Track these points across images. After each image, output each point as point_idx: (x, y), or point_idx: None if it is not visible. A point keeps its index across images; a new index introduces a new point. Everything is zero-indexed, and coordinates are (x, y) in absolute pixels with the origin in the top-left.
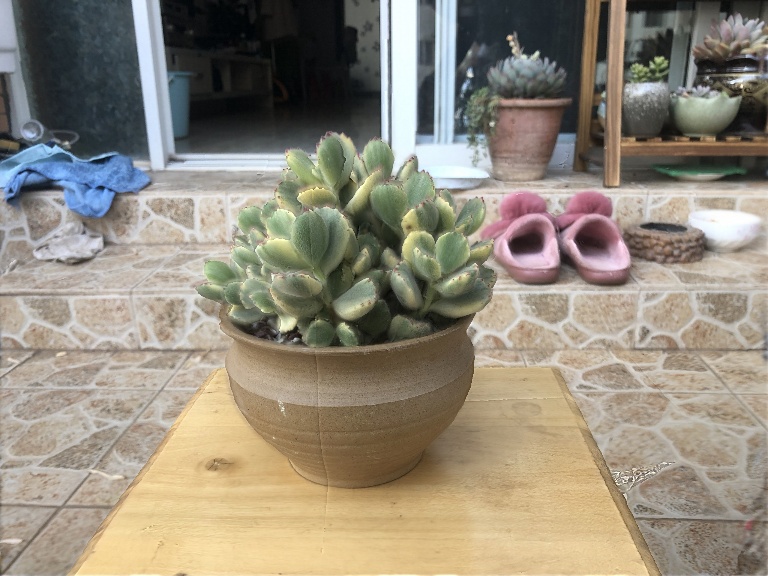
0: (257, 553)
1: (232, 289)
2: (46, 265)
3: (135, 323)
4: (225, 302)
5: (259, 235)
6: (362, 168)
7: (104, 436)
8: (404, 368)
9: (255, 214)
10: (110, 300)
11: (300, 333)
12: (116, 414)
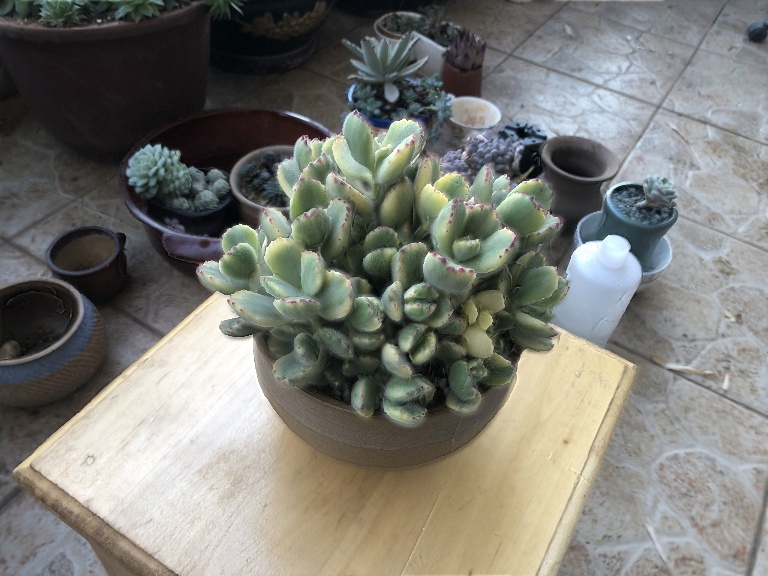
0: None
1: None
2: None
3: None
4: None
5: None
6: None
7: None
8: None
9: (494, 185)
10: None
11: None
12: None
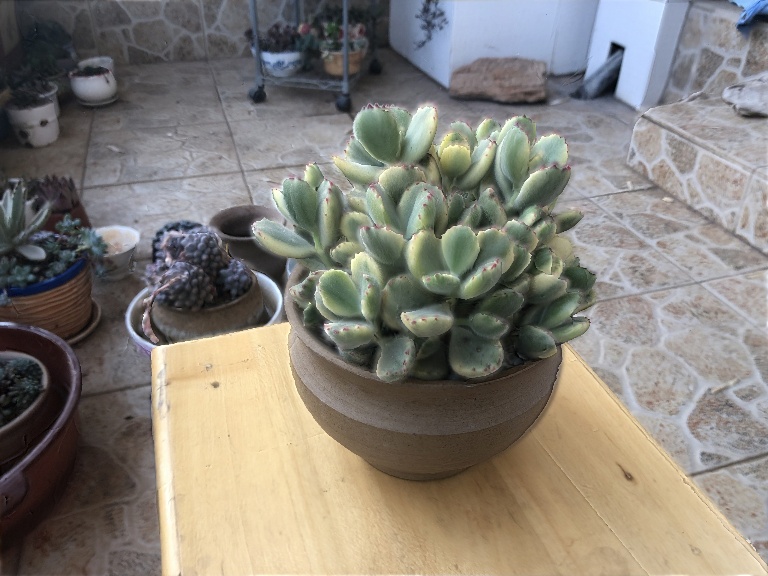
0: (249, 414)
1: None
2: (721, 107)
3: (742, 204)
4: None
5: None
6: (499, 153)
7: (605, 289)
8: (334, 375)
9: None
10: (732, 169)
11: None
12: (637, 278)
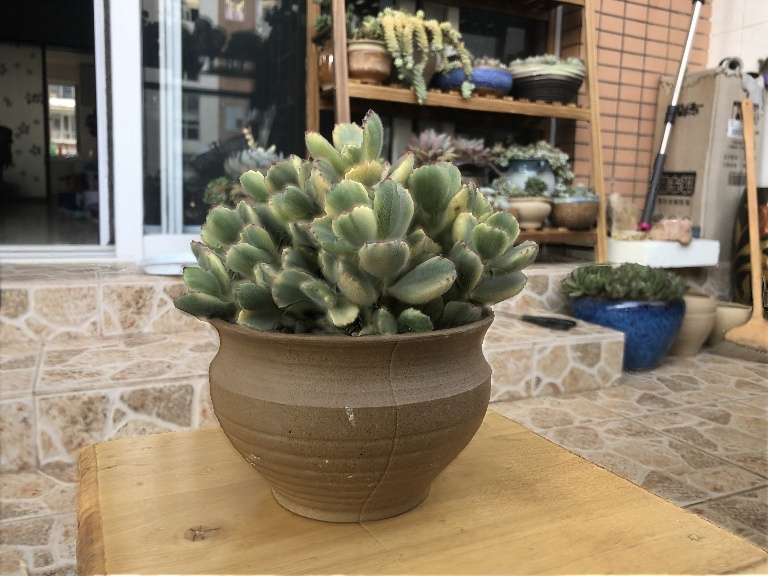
0: None
1: (247, 290)
2: None
3: None
4: (214, 315)
5: (263, 230)
6: None
7: None
8: (465, 356)
9: (231, 215)
10: None
11: (360, 326)
12: None
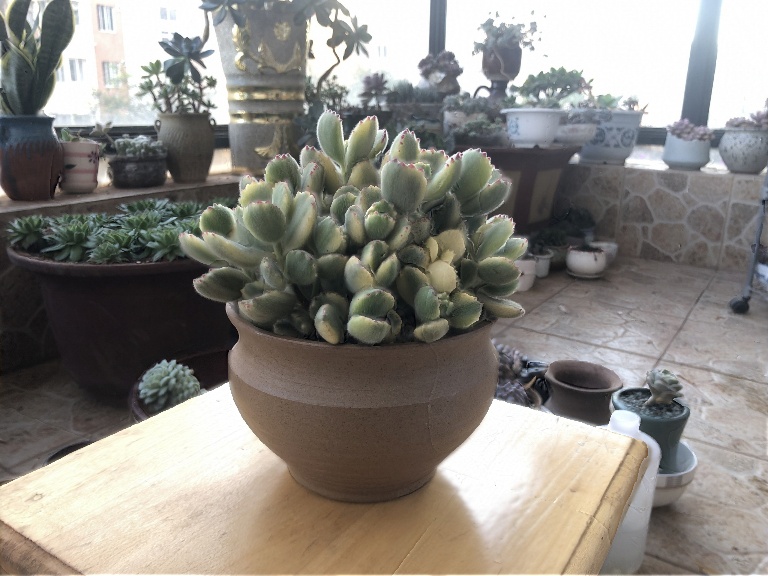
0: None
1: None
2: None
3: None
4: None
5: None
6: None
7: None
8: None
9: None
10: None
11: None
12: None
